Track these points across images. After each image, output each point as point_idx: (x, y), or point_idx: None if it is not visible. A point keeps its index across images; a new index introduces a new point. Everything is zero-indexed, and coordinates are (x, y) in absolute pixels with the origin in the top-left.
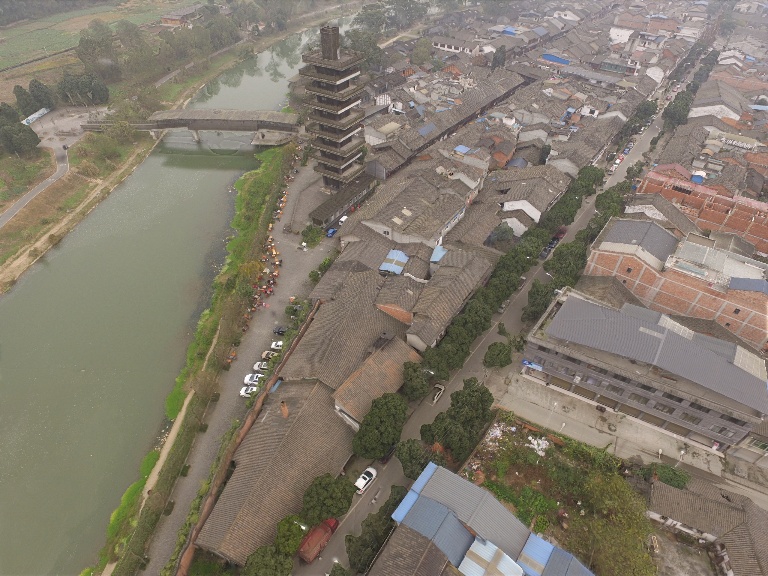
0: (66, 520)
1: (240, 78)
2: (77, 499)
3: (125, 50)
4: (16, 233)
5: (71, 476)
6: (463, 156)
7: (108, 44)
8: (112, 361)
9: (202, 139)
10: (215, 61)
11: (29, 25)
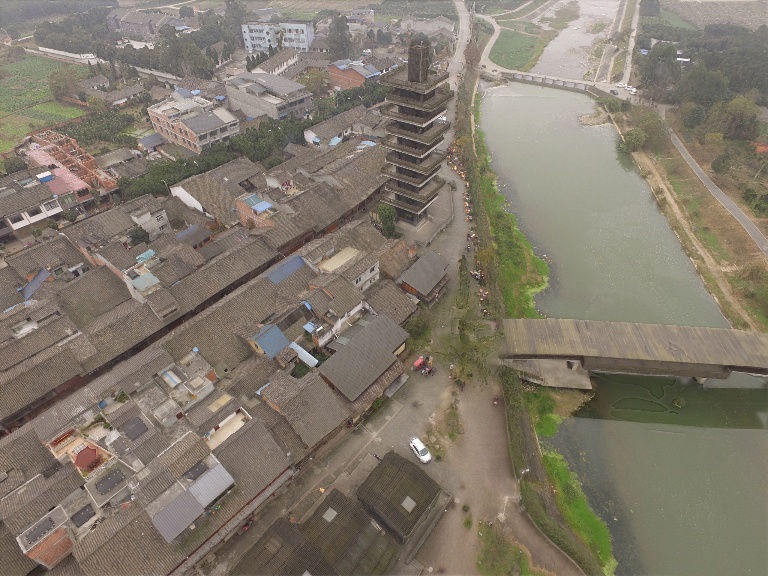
0: (497, 112)
1: None
2: (497, 115)
3: None
4: (700, 201)
5: (505, 118)
6: None
7: None
8: (526, 144)
9: (691, 379)
10: None
11: None
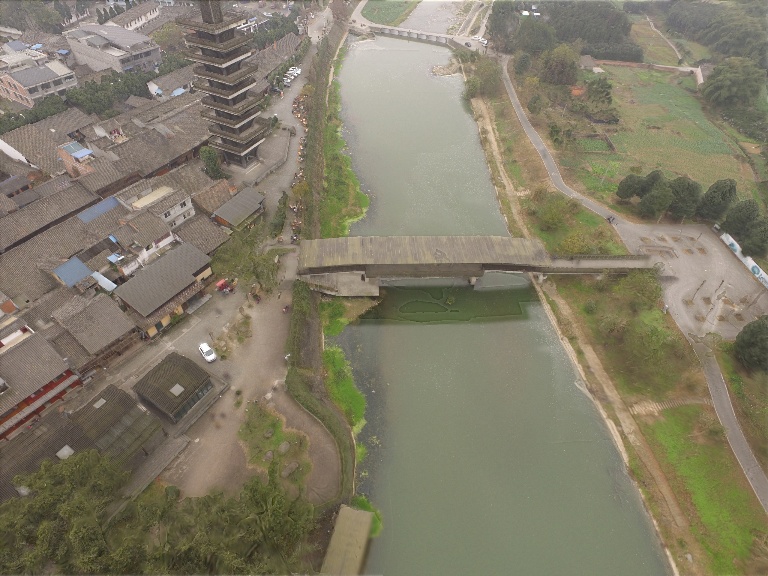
0: None
1: None
2: None
3: None
4: (515, 138)
5: (364, 70)
6: None
7: None
8: None
9: (466, 282)
10: None
11: None
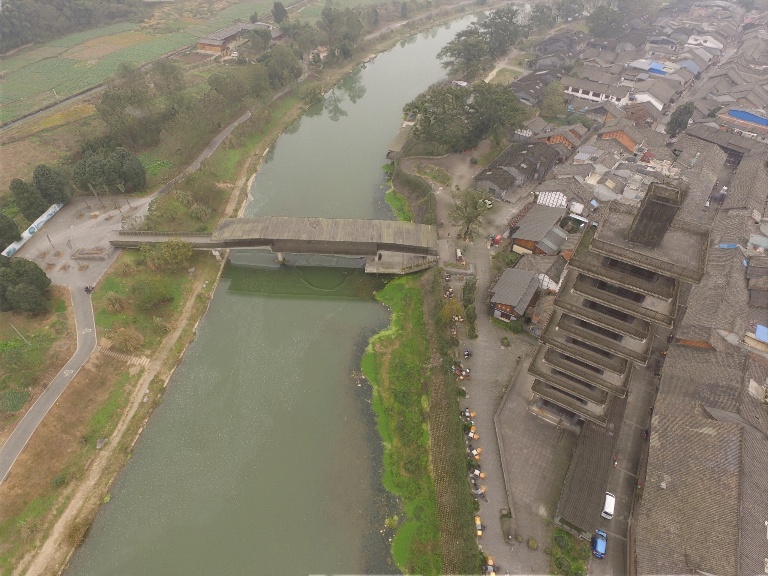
0: None
1: (299, 123)
2: None
3: (157, 92)
4: (8, 522)
5: None
6: (759, 341)
7: (142, 99)
8: None
9: (288, 258)
10: (275, 109)
11: (34, 51)
